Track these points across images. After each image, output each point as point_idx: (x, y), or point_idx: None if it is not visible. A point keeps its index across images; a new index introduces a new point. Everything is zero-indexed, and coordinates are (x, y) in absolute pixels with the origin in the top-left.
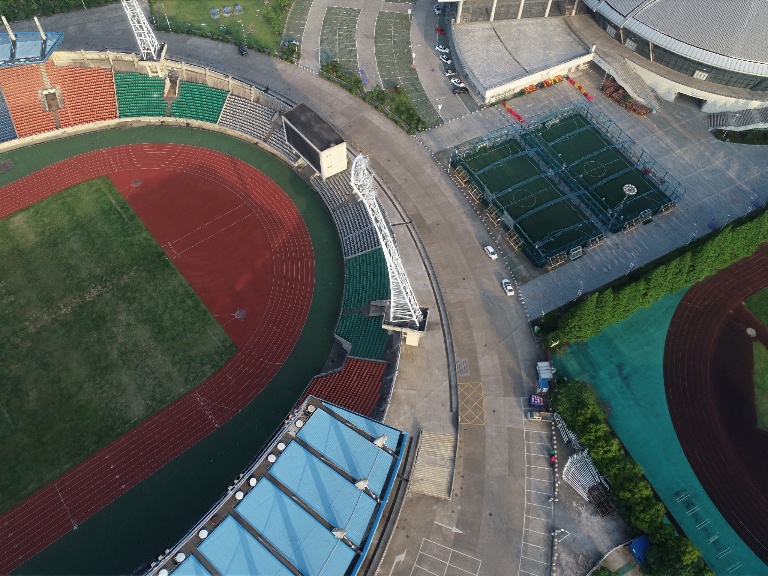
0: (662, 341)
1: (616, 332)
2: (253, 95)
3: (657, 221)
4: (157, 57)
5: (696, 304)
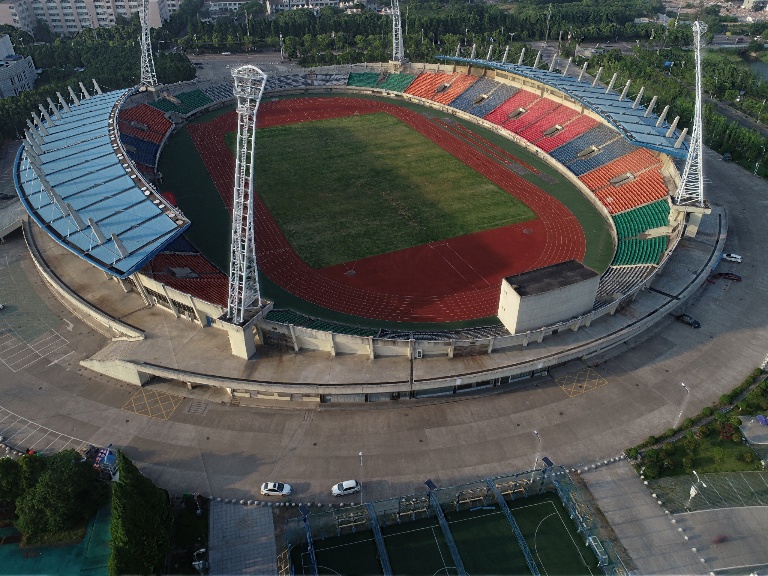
0: None
1: None
2: None
3: None
4: None
5: None
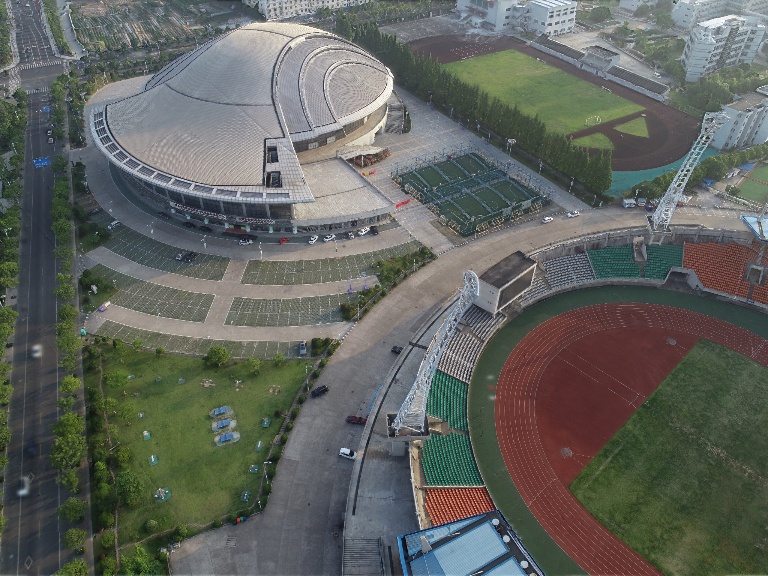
0: None
1: None
2: None
3: None
4: None
5: None
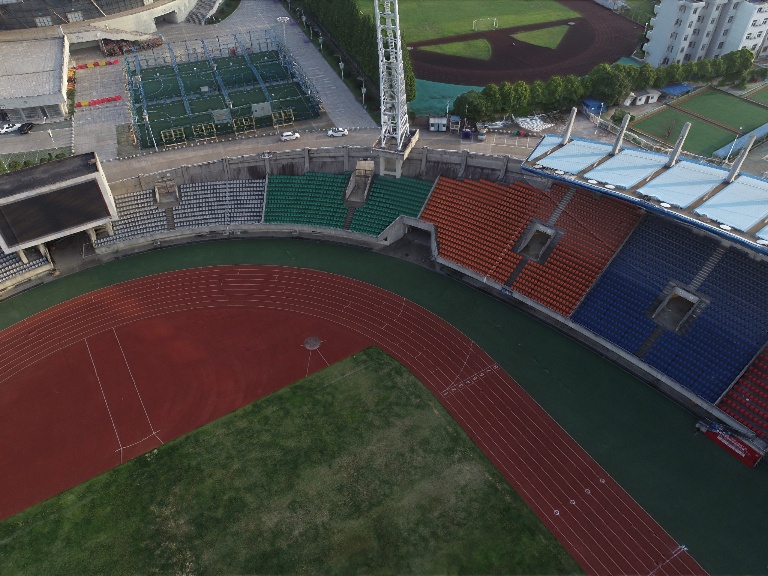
0: None
1: None
2: None
3: None
4: None
5: None
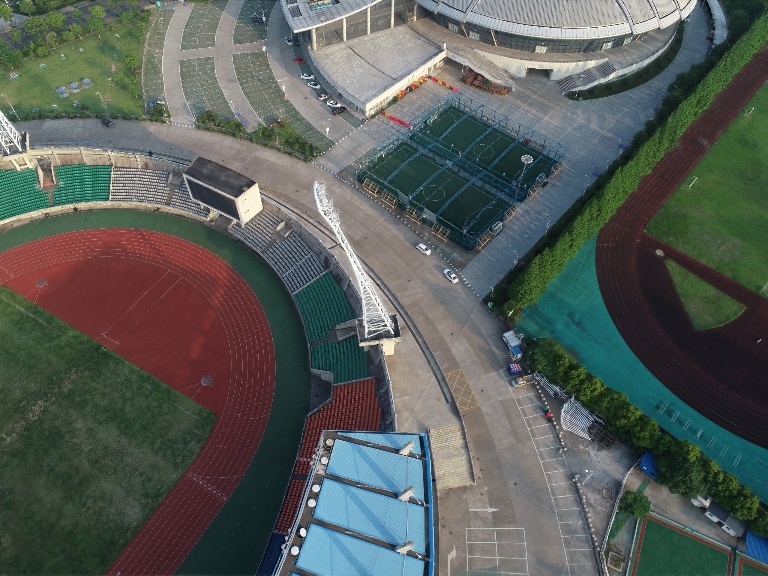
0: (595, 282)
1: (556, 287)
2: (140, 162)
3: (552, 182)
4: (22, 148)
5: (609, 243)
